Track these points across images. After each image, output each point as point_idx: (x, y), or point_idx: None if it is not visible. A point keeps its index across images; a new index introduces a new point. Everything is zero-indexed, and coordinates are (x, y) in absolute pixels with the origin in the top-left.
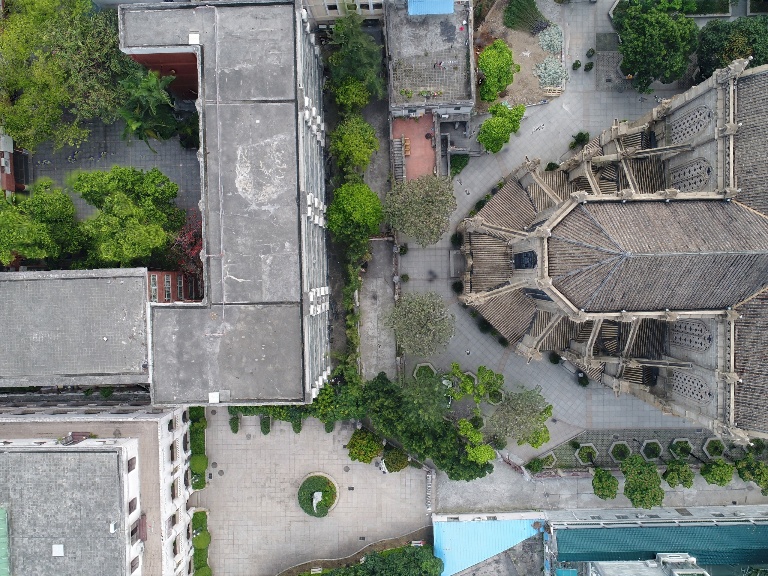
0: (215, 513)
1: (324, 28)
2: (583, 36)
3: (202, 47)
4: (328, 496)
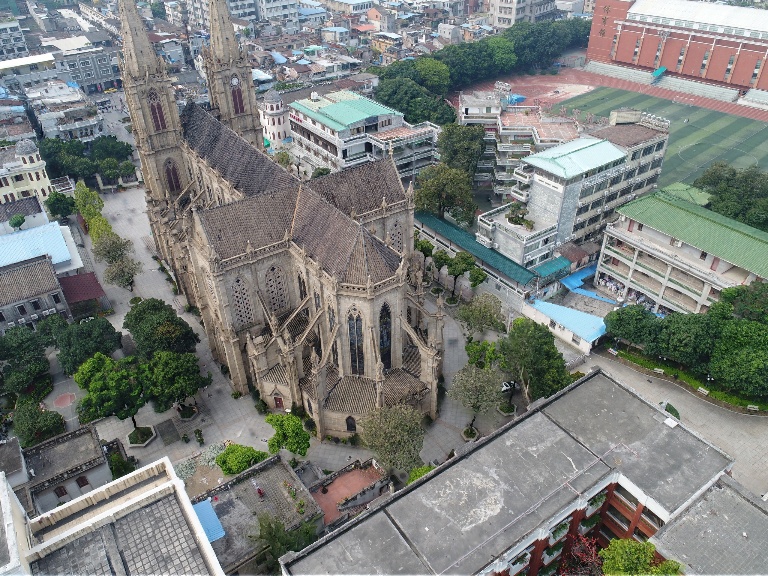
0: (767, 482)
1: None
2: (171, 453)
3: None
4: None
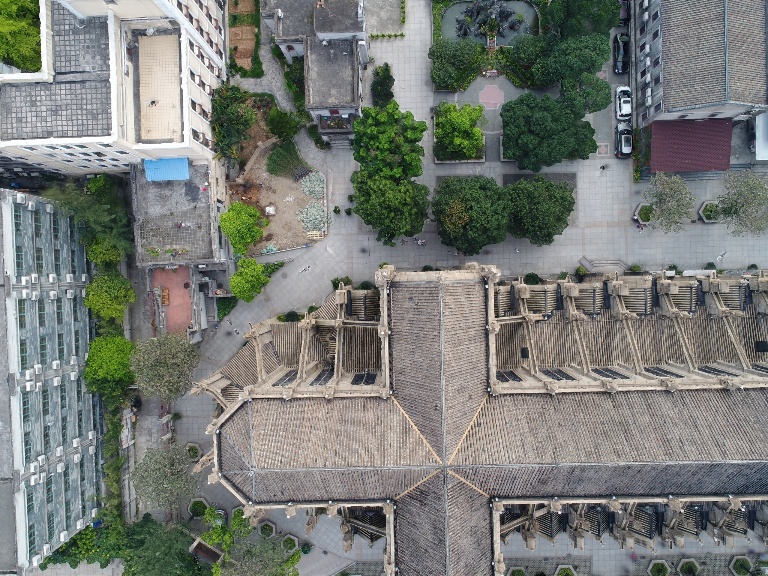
0: None
1: (92, 177)
2: (345, 181)
3: None
4: None
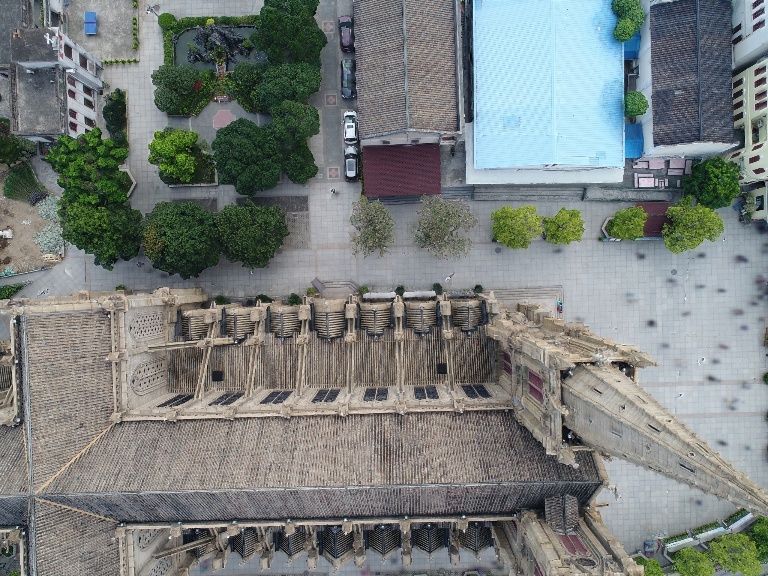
0: None
1: None
2: None
3: None
4: None
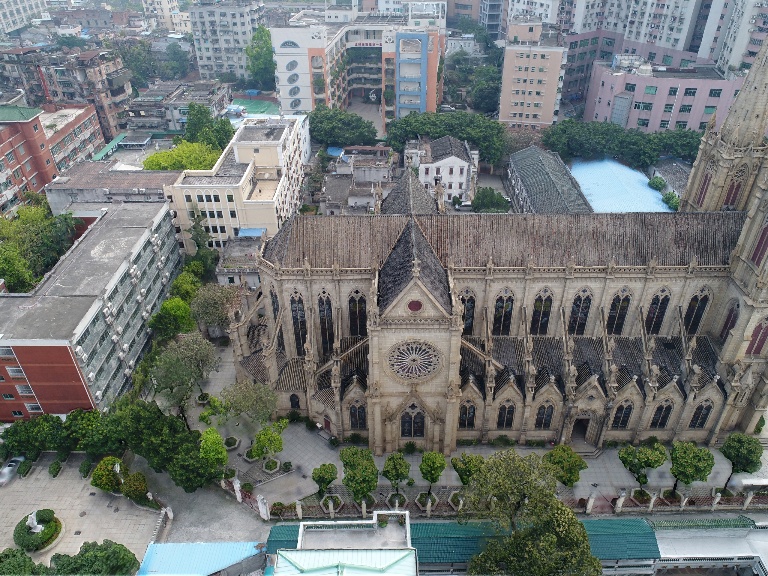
0: None
1: None
2: None
3: (107, 212)
4: (49, 530)
